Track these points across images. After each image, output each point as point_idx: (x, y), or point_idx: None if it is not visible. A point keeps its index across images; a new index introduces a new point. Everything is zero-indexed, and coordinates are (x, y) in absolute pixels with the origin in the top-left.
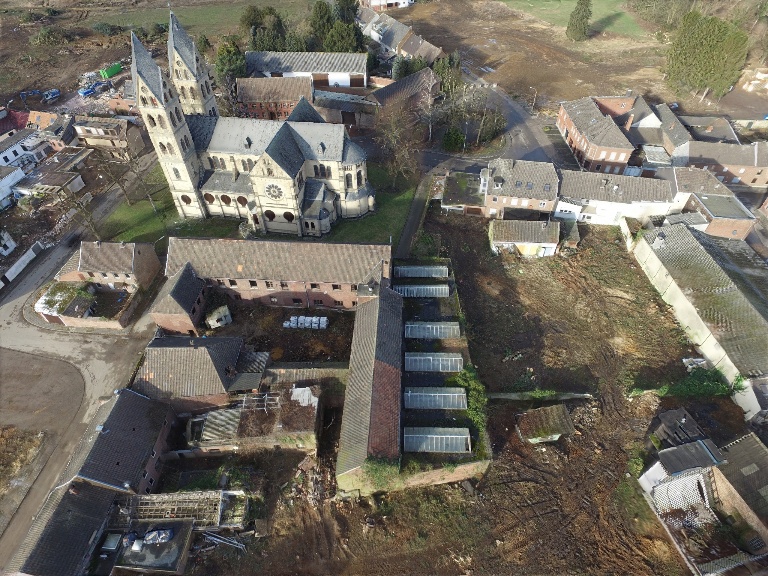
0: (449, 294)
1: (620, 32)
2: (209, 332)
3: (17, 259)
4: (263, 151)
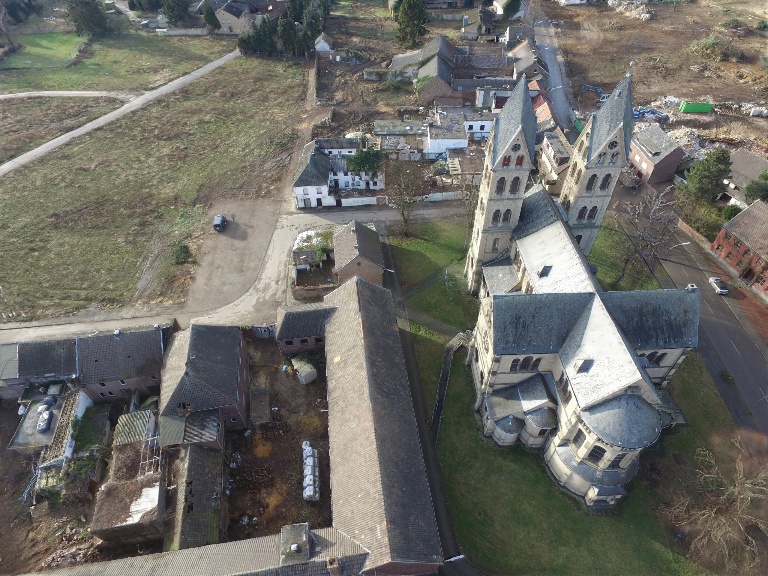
0: None
1: None
2: (290, 369)
3: (360, 196)
4: None
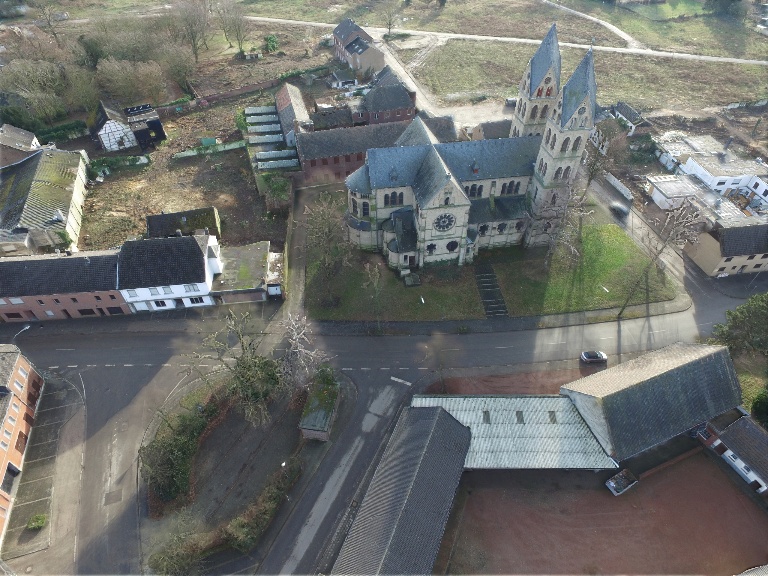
0: None
1: None
2: None
3: None
4: None
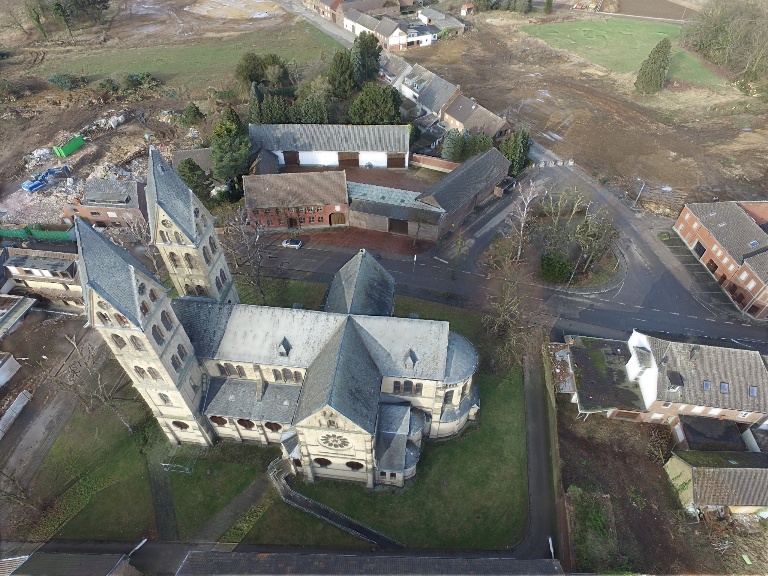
0: None
1: (692, 80)
2: None
3: None
4: (310, 361)
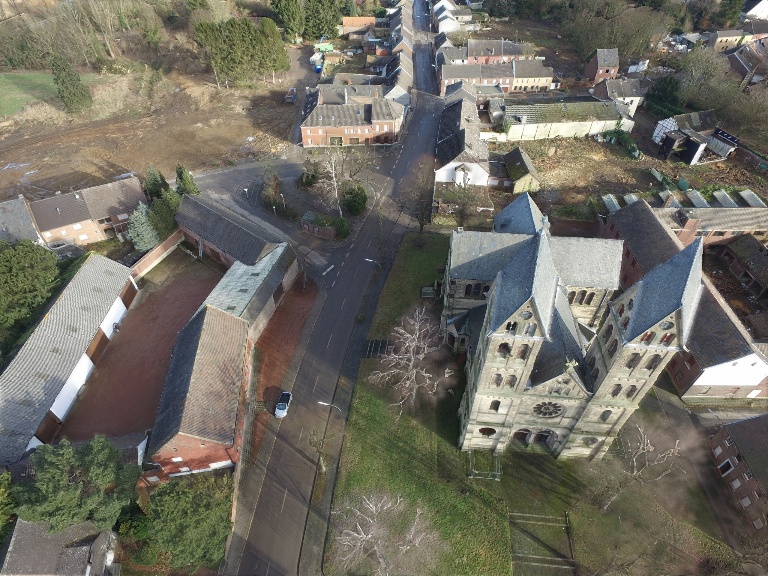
0: None
1: None
2: None
3: None
4: (561, 280)
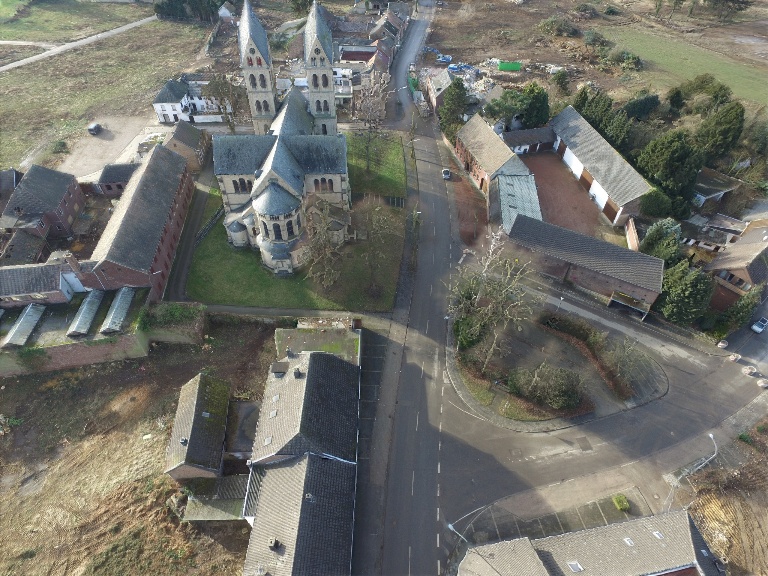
0: (71, 336)
1: None
2: None
3: None
4: None
